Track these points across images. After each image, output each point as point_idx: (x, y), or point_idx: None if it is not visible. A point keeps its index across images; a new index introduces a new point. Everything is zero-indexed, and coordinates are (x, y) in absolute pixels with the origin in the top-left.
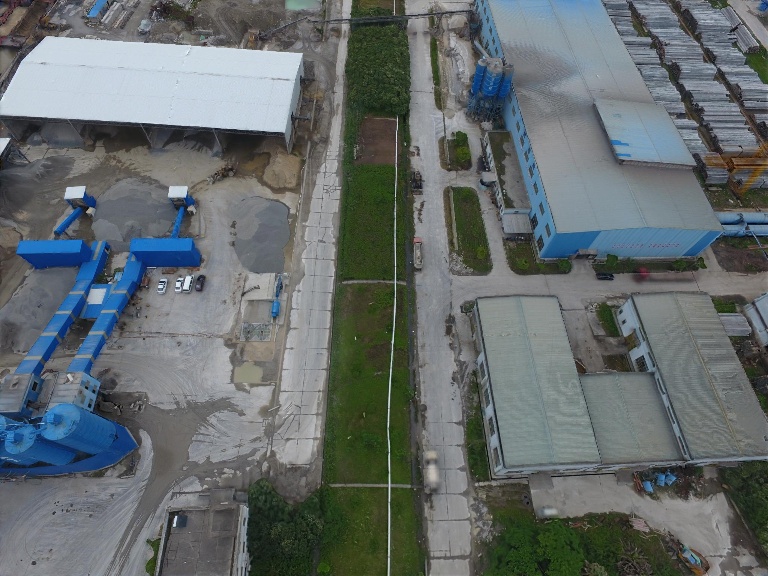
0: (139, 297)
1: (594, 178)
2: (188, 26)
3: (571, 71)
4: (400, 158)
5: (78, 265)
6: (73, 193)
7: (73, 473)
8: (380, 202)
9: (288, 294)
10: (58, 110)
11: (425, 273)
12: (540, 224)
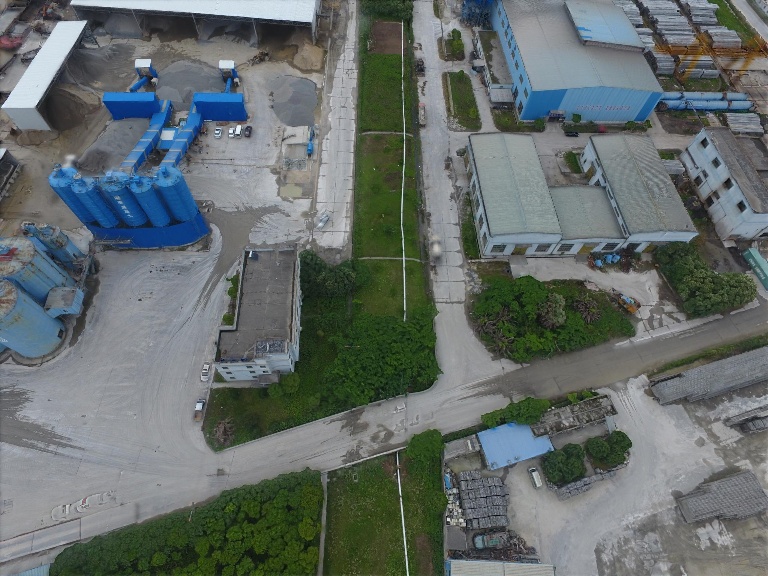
0: (200, 140)
1: (563, 55)
2: None
3: None
4: (406, 50)
5: (149, 117)
6: (141, 63)
7: (162, 248)
8: (390, 79)
9: (319, 141)
10: (123, 2)
11: (428, 129)
12: (520, 92)
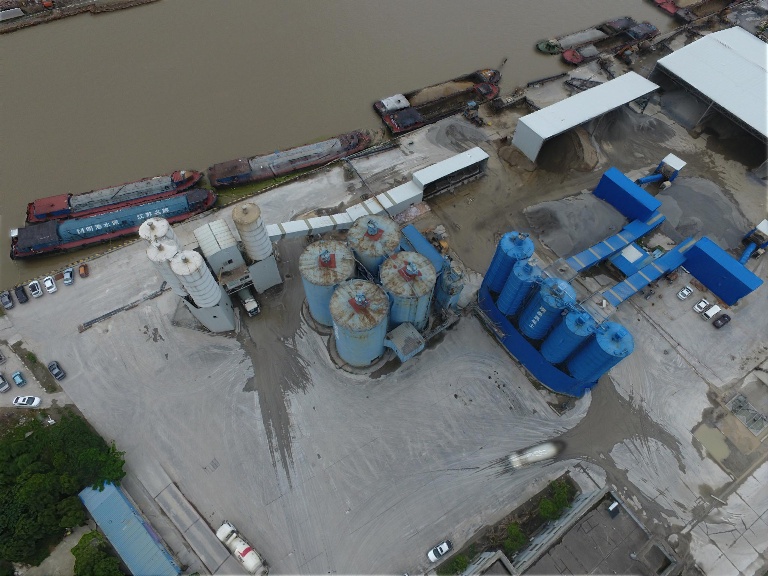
0: (657, 283)
1: None
2: None
3: None
4: None
5: (629, 217)
6: (673, 161)
7: (521, 364)
8: None
9: None
10: (711, 89)
11: None
12: None
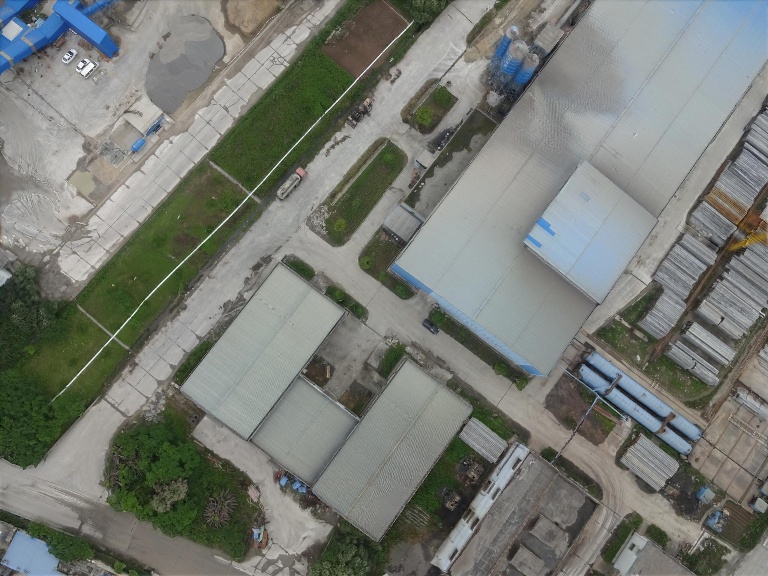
0: (47, 53)
1: (487, 240)
2: None
3: (613, 107)
4: (370, 73)
5: None
6: None
7: None
8: (304, 109)
9: (160, 138)
10: None
11: (284, 205)
12: None
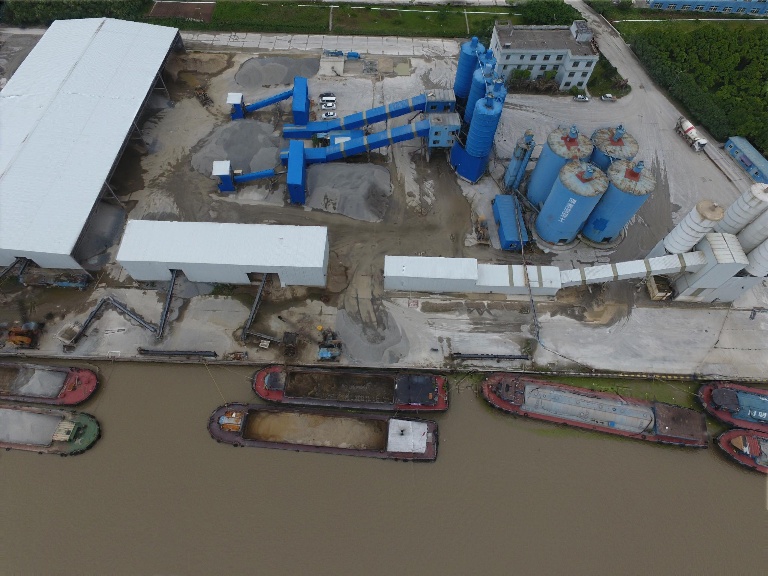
0: None
1: None
2: None
3: None
4: (207, 1)
5: (305, 168)
6: (222, 169)
7: None
8: (257, 8)
9: None
10: (85, 191)
11: None
12: None
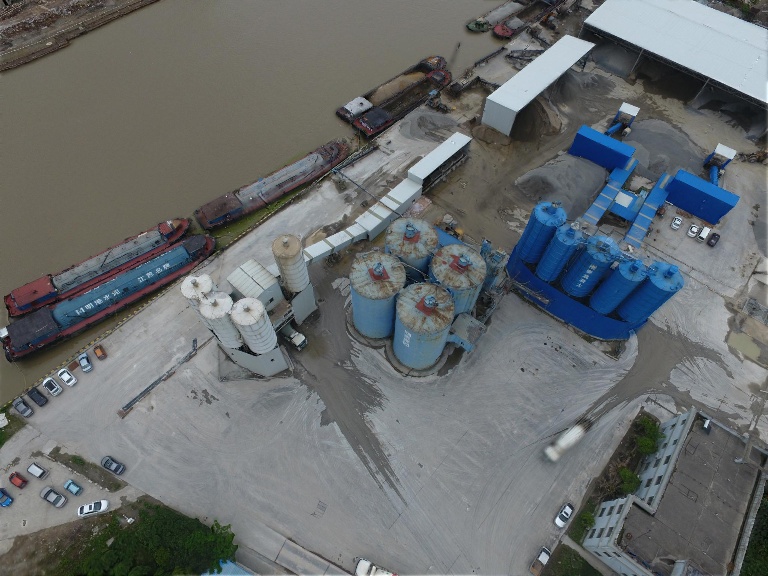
0: None
1: None
2: (746, 17)
3: None
4: None
5: (607, 167)
6: (628, 109)
7: (568, 324)
8: None
9: None
10: (638, 39)
11: None
12: None
